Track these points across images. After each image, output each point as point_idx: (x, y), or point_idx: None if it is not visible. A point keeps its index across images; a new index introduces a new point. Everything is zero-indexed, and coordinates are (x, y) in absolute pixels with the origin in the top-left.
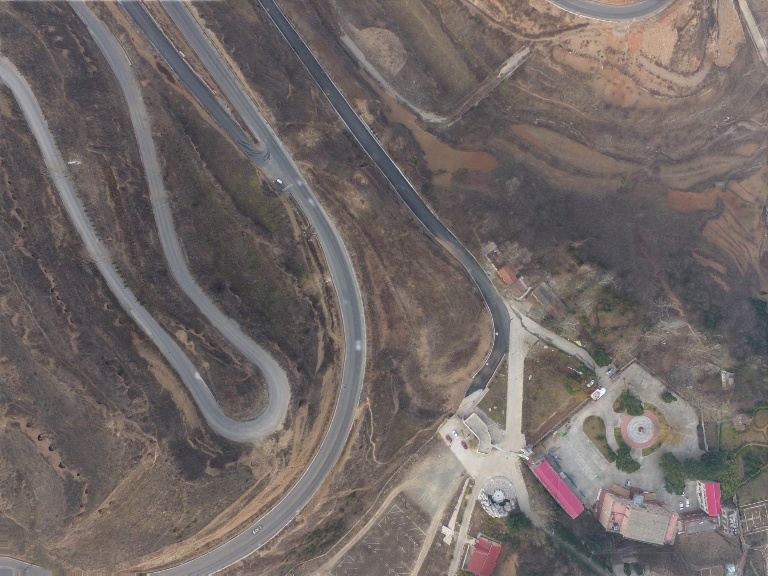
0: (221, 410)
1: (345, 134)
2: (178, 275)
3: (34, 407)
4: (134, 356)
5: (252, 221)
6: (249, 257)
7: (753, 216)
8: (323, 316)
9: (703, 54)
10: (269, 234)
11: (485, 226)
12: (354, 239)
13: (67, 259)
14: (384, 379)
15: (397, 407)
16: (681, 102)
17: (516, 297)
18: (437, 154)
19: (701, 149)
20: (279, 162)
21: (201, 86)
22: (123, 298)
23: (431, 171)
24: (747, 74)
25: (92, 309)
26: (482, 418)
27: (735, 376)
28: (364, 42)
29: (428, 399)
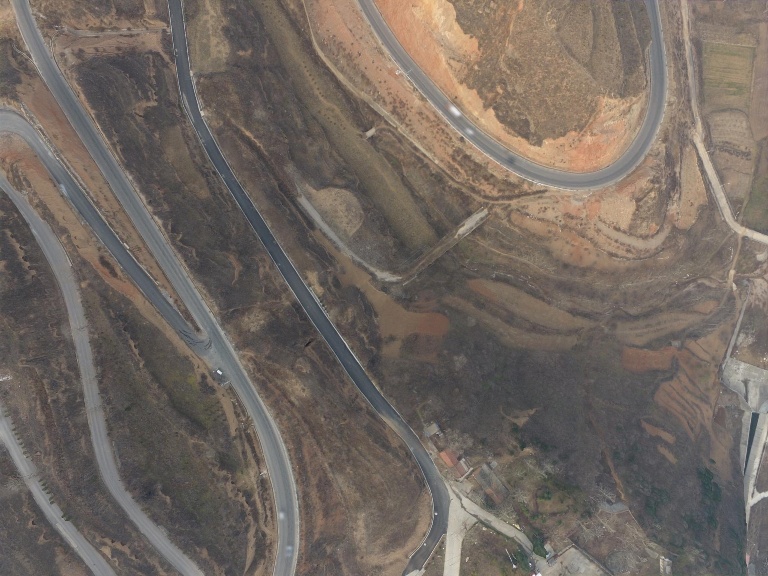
0: None
1: (294, 306)
2: (109, 480)
3: None
4: None
5: (188, 419)
6: (182, 458)
7: (708, 375)
8: (256, 511)
9: (663, 217)
10: (205, 431)
11: (427, 410)
12: (292, 430)
13: None
14: (316, 571)
15: None
16: (639, 264)
17: None
18: (390, 316)
19: (659, 305)
20: (220, 351)
21: (145, 277)
22: (49, 512)
23: (381, 338)
24: (706, 239)
25: (15, 532)
26: None
27: (673, 563)
28: (321, 203)
29: None
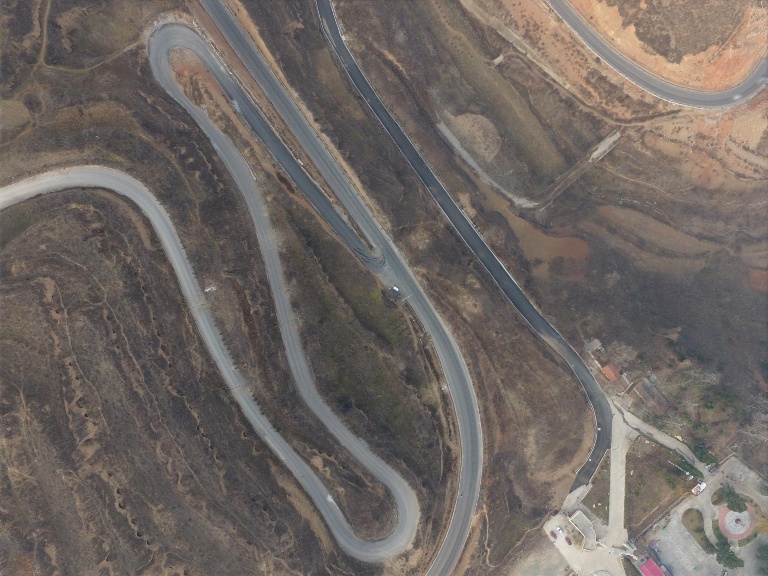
0: (352, 531)
1: (448, 229)
2: (306, 394)
3: (190, 554)
4: (274, 487)
5: (374, 334)
6: (373, 372)
7: None
8: (441, 425)
9: None
10: (390, 346)
11: (591, 325)
12: (469, 345)
13: (208, 391)
14: (499, 485)
15: (508, 509)
16: (765, 184)
17: (618, 392)
18: (531, 241)
19: None
20: (395, 268)
21: (318, 194)
22: (258, 424)
23: (528, 261)
24: None
25: (233, 442)
26: (586, 514)
27: None
28: (459, 129)
29: (534, 497)
